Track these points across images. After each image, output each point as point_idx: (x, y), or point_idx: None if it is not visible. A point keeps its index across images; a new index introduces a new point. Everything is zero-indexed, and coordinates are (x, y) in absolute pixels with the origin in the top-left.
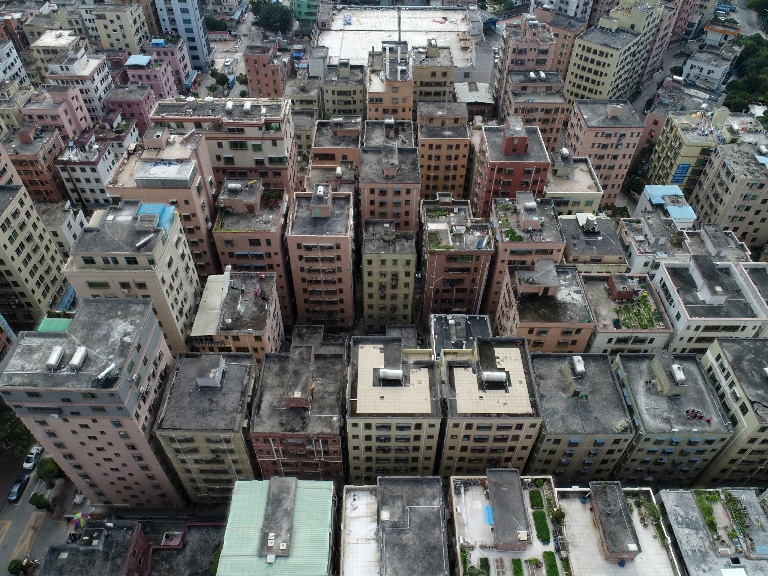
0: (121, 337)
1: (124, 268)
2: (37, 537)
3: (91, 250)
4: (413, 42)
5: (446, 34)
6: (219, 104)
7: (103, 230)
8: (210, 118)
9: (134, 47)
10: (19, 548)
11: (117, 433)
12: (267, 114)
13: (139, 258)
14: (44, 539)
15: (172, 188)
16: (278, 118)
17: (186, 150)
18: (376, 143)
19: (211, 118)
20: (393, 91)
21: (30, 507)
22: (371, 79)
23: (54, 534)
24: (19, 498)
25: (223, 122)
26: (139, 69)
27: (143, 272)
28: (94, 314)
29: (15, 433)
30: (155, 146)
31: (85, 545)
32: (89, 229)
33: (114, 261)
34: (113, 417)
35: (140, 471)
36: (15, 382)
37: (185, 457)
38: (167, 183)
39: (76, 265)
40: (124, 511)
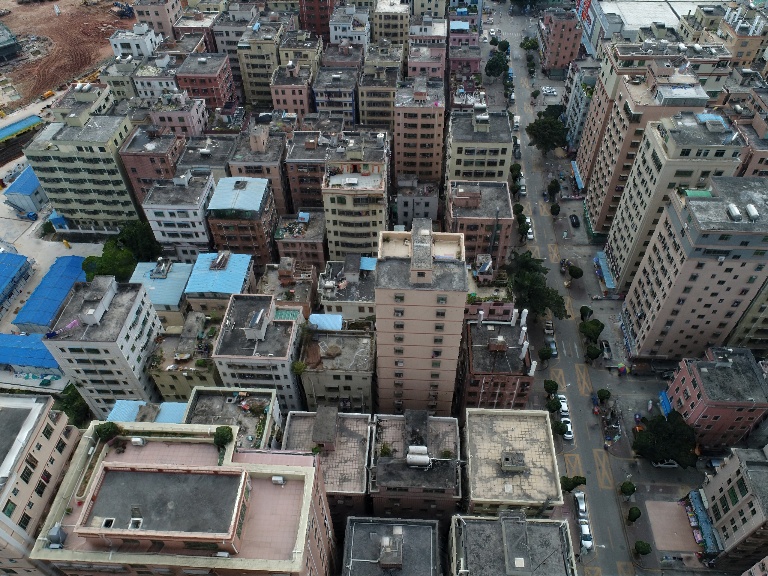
0: (764, 202)
1: (714, 159)
2: (591, 380)
3: (688, 144)
4: (686, 11)
5: (712, 4)
6: (667, 46)
7: (683, 131)
8: (672, 56)
9: (442, 15)
10: (582, 387)
11: (748, 278)
12: (721, 53)
13: (728, 151)
14: (598, 382)
15: (690, 106)
16: (730, 56)
17: (689, 77)
18: (735, 90)
19: (673, 56)
20: (742, 45)
21: (570, 360)
22: (711, 36)
23: (604, 378)
24: (557, 354)
25: (685, 59)
26: (462, 33)
27: (731, 162)
28: (727, 187)
29: (555, 302)
30: (665, 74)
31: (724, 362)
32: (673, 130)
33: (705, 153)
34: (763, 261)
35: (718, 319)
36: (714, 227)
37: (767, 306)
38: (689, 102)
39: (672, 157)
40: (654, 364)
